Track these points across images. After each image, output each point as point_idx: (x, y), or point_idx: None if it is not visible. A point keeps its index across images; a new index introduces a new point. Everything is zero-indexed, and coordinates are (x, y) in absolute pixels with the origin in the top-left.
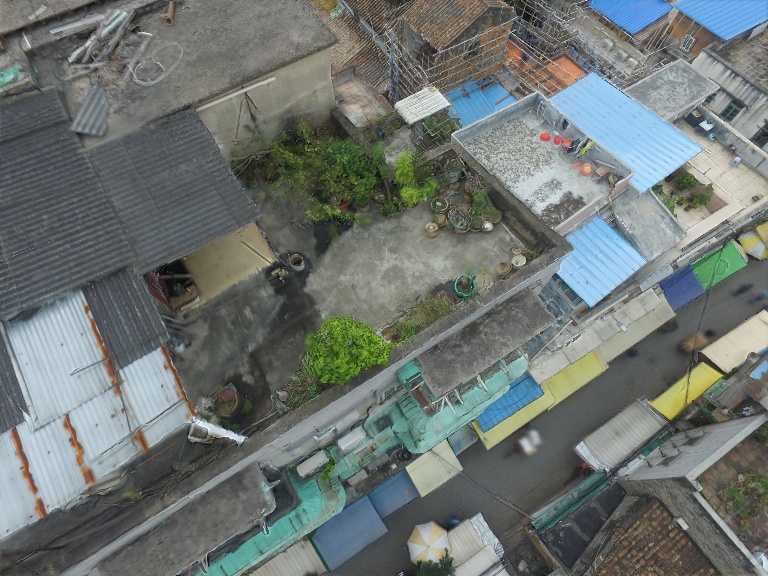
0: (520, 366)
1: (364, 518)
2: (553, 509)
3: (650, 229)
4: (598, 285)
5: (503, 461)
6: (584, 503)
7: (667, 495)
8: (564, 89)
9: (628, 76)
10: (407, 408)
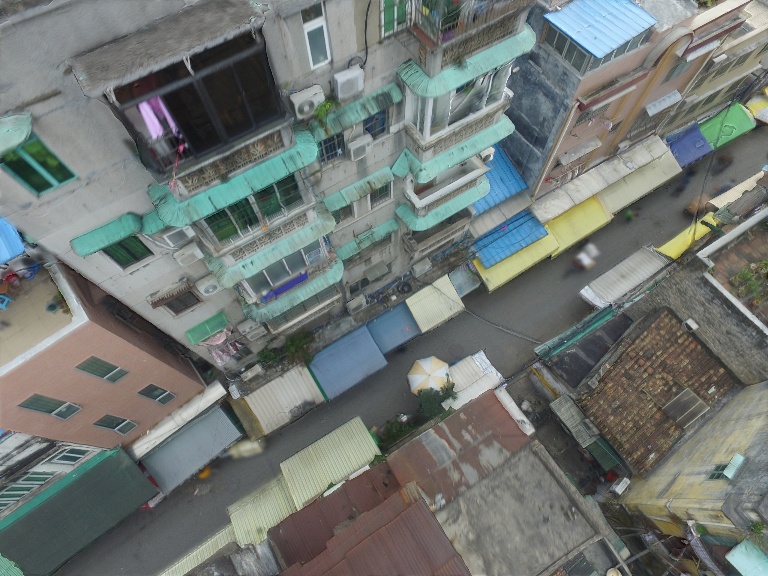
0: (528, 40)
1: (363, 349)
2: (557, 339)
3: (660, 4)
4: (607, 40)
5: (505, 315)
6: (589, 332)
7: (676, 296)
8: None
9: None
10: (408, 74)
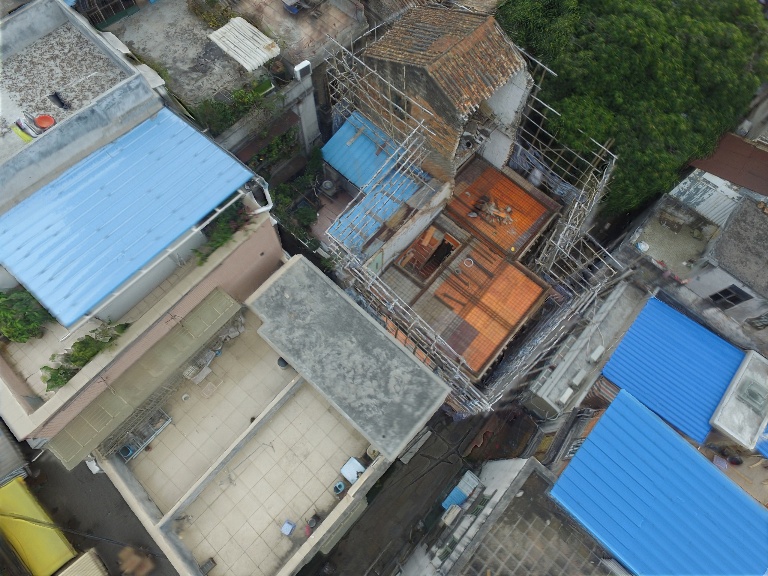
0: None
1: None
2: None
3: None
4: None
5: None
6: None
7: None
8: (210, 140)
9: (540, 395)
10: None
